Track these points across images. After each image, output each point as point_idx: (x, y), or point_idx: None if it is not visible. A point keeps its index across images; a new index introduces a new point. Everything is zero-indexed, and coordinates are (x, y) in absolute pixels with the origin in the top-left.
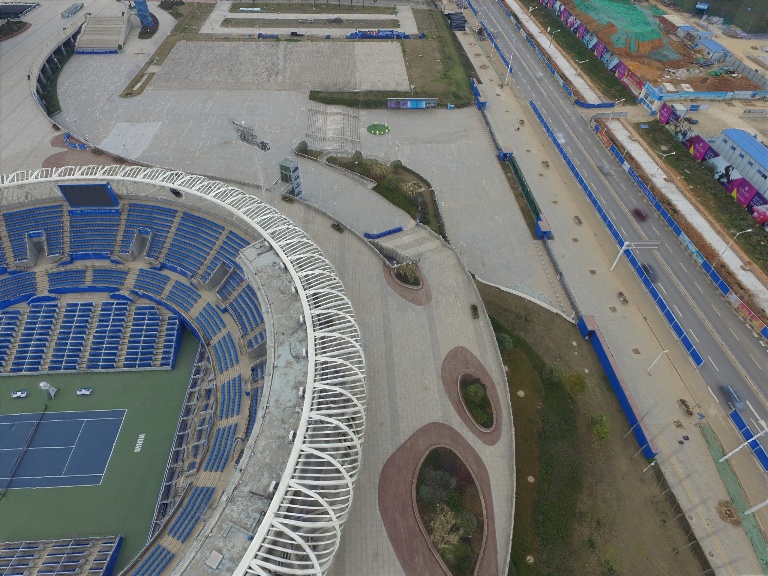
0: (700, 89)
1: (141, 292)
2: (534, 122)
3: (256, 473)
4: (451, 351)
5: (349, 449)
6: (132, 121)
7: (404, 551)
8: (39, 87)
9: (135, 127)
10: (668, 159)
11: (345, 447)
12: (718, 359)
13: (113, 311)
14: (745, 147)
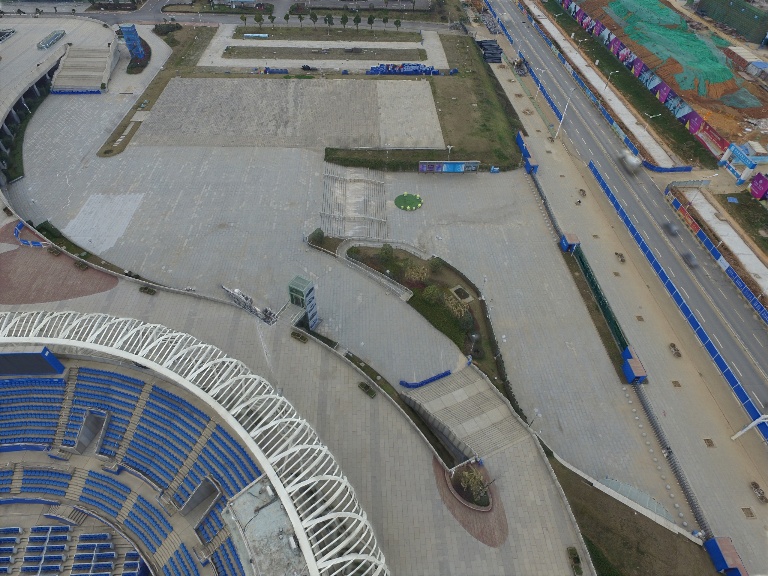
0: None
1: (88, 512)
2: (597, 192)
3: None
4: None
5: None
6: (108, 192)
7: None
8: (0, 143)
9: (111, 201)
10: None
11: None
12: None
13: (46, 544)
14: None
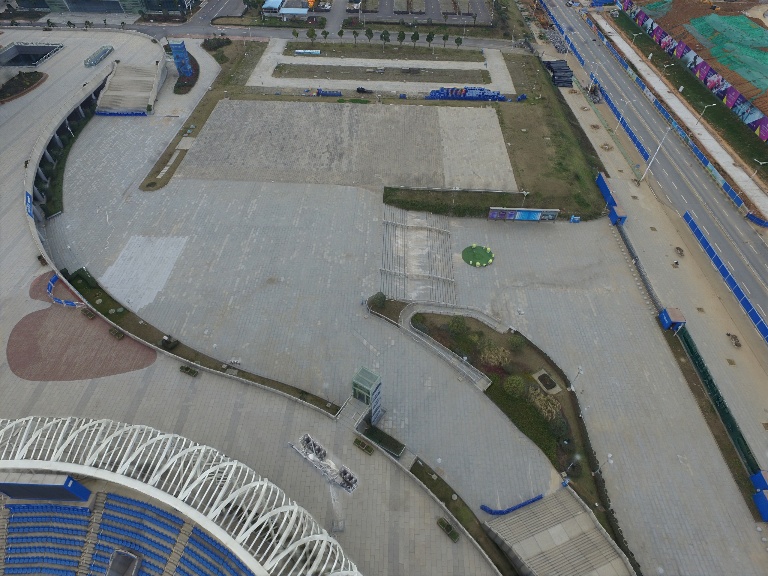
0: None
1: None
2: (696, 251)
3: None
4: None
5: None
6: (150, 234)
7: None
8: (41, 172)
9: (152, 245)
10: None
11: None
12: None
13: None
14: None
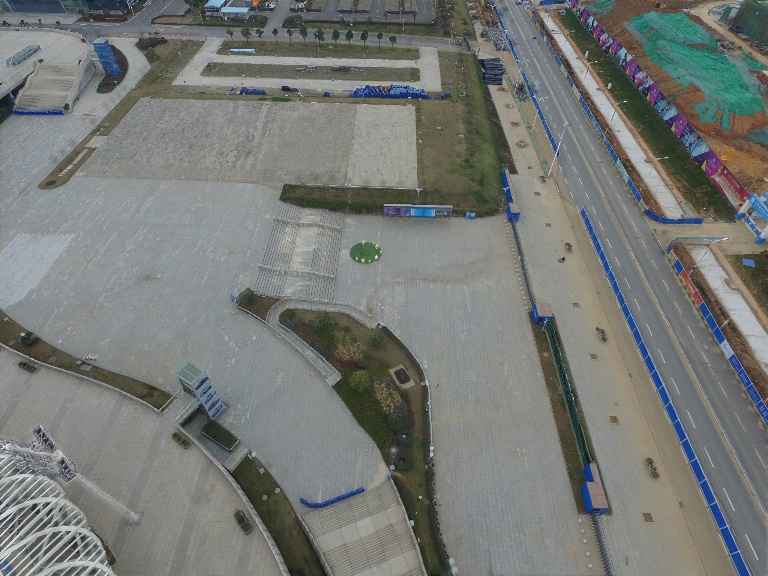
0: None
1: None
2: (586, 246)
3: None
4: None
5: None
6: (37, 232)
7: None
8: None
9: (37, 243)
10: None
11: None
12: None
13: None
14: None
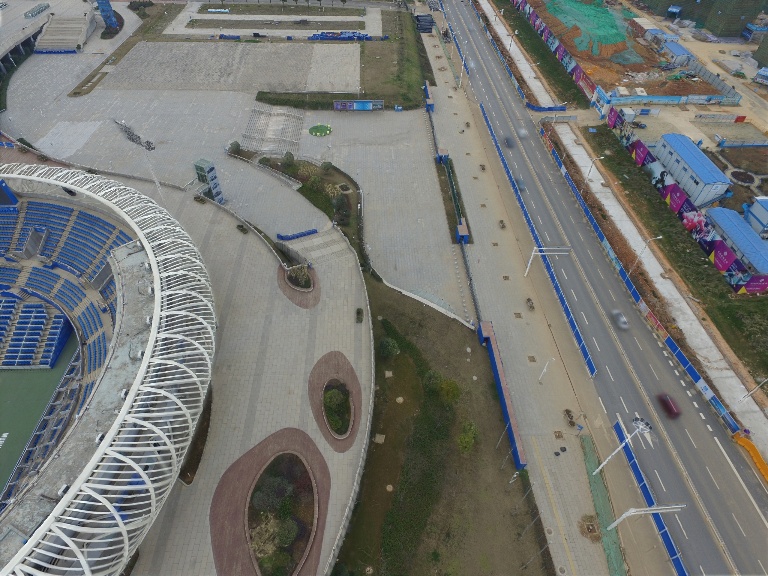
0: (657, 93)
1: (30, 290)
2: (481, 125)
3: (54, 476)
4: (325, 355)
5: (158, 453)
6: (73, 120)
7: (224, 559)
8: None
9: (75, 126)
10: (609, 164)
11: (153, 451)
12: (615, 369)
13: (0, 309)
14: (681, 152)
